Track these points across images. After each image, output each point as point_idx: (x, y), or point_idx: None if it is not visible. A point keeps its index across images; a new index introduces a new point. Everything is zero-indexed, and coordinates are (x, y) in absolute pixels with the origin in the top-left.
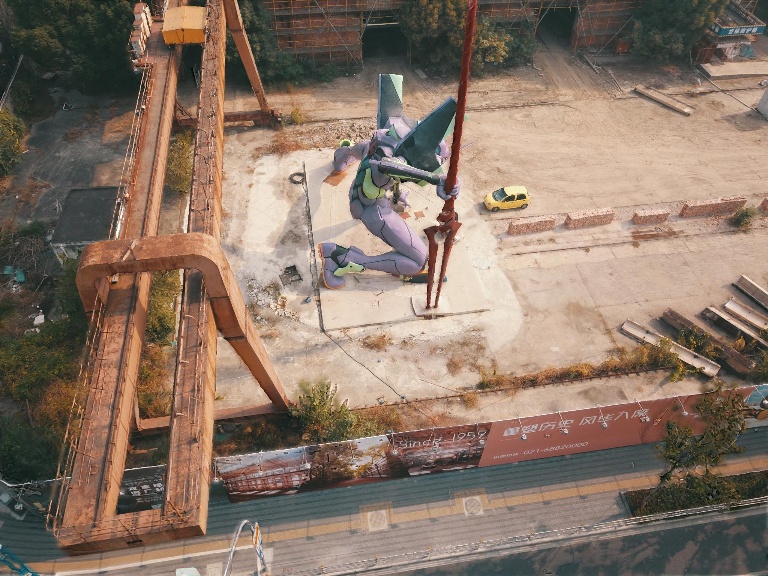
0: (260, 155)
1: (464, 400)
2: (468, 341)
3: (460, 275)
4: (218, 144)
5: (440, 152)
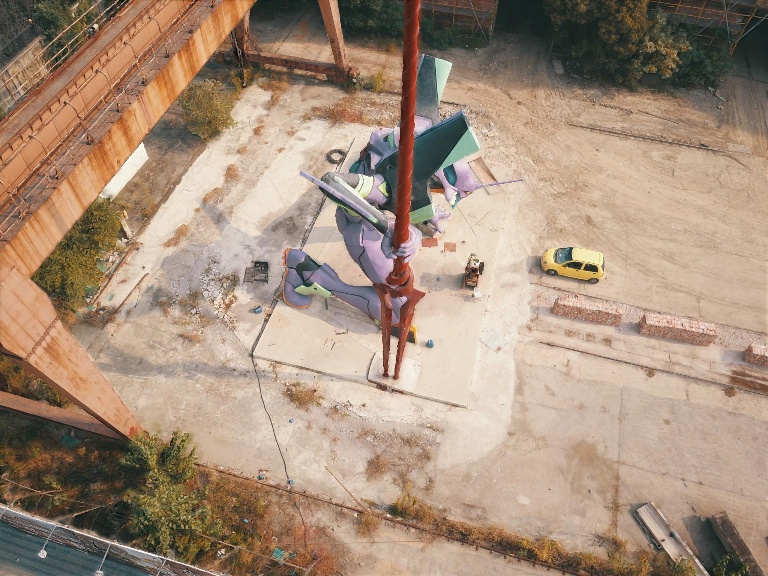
0: (312, 117)
1: (361, 520)
2: (414, 439)
3: (454, 345)
4: (153, 94)
5: (456, 182)
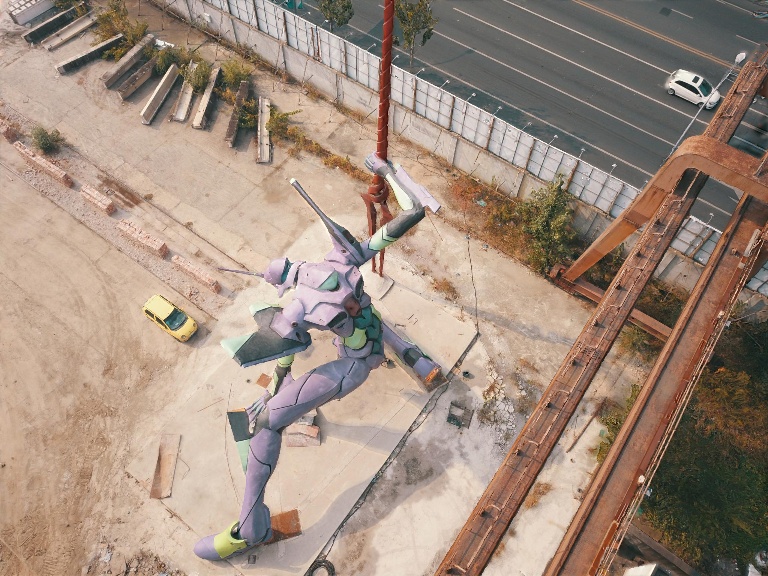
0: None
1: None
2: None
3: None
4: None
5: None
